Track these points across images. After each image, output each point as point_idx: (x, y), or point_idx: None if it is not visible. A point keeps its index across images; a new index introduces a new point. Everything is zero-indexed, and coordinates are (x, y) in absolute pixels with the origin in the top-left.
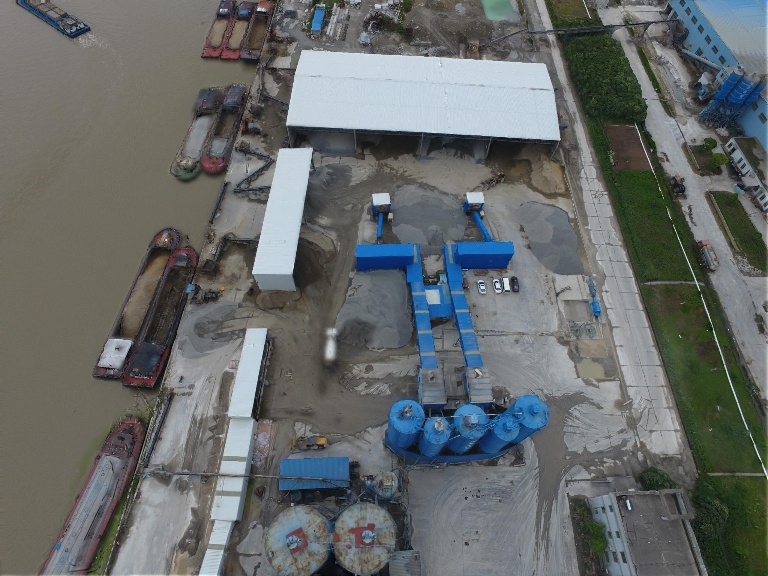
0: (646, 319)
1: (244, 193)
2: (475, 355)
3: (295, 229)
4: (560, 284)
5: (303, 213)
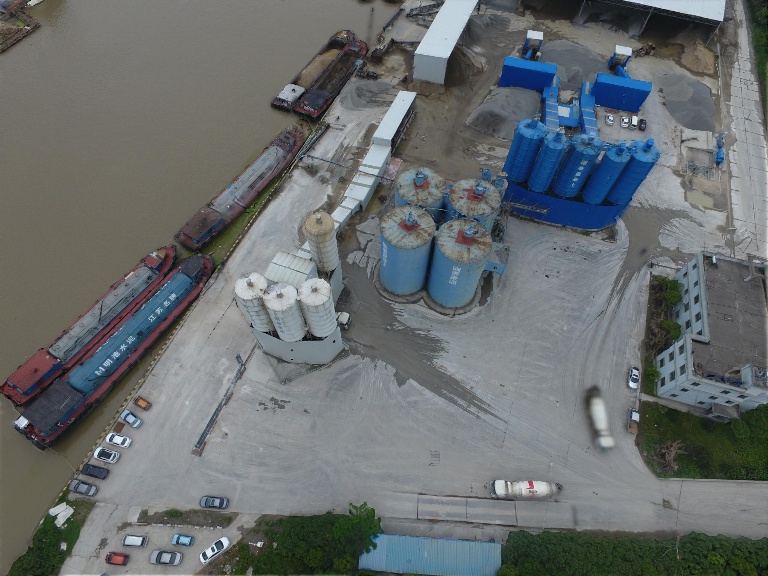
0: None
1: (415, 18)
2: None
3: (457, 32)
4: (688, 135)
5: (461, 39)
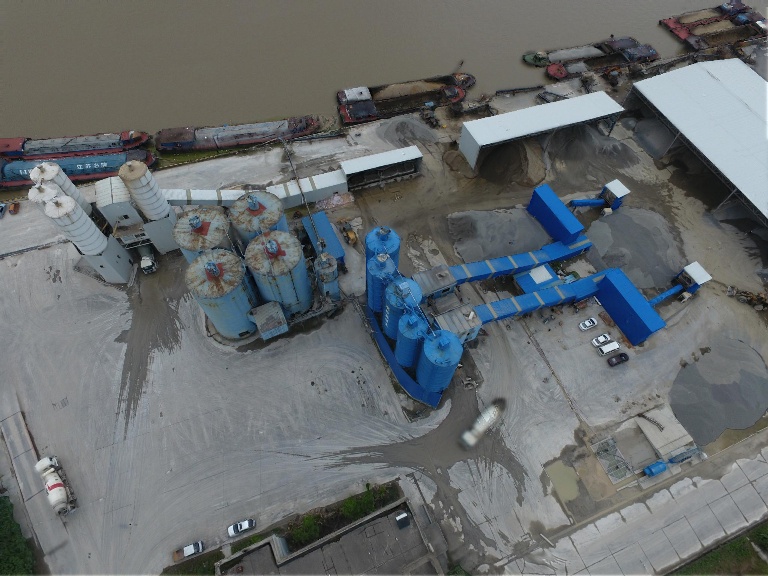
0: (692, 553)
1: (542, 101)
2: (491, 313)
3: (526, 131)
4: (659, 416)
5: (555, 145)
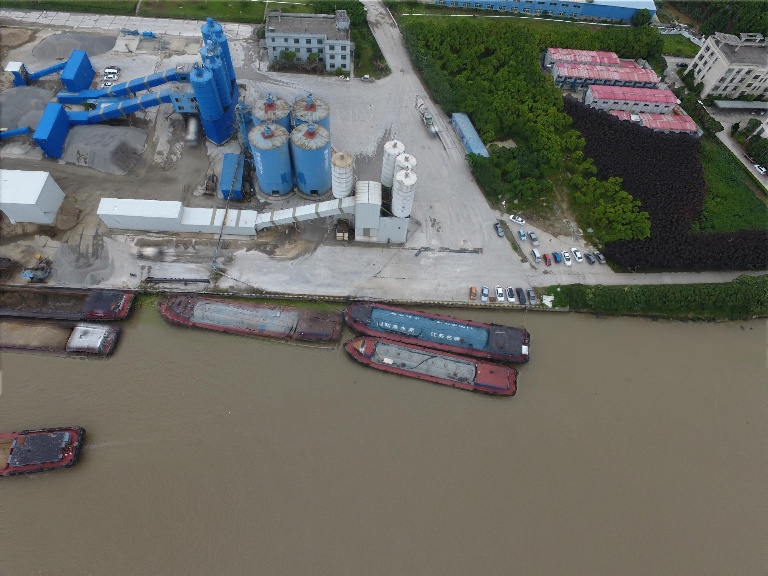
0: (164, 19)
1: None
2: (166, 72)
3: None
4: (122, 49)
5: None
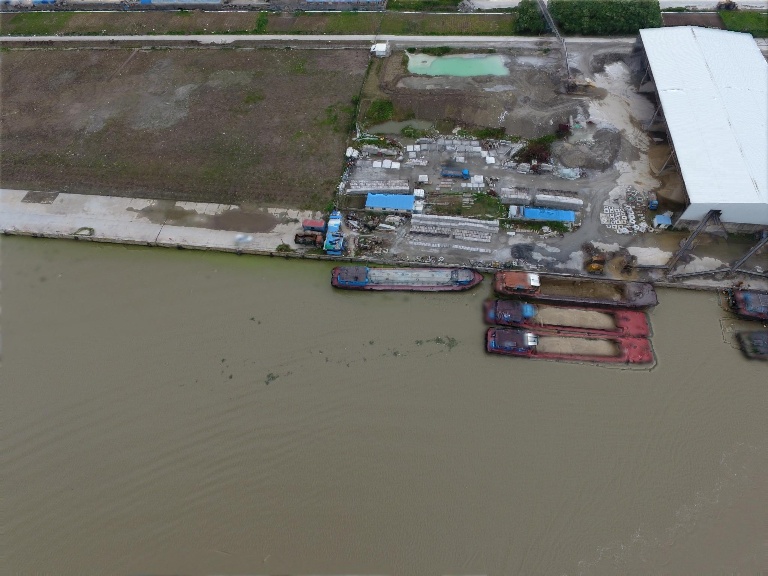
0: None
1: None
2: None
3: None
4: None
5: None
